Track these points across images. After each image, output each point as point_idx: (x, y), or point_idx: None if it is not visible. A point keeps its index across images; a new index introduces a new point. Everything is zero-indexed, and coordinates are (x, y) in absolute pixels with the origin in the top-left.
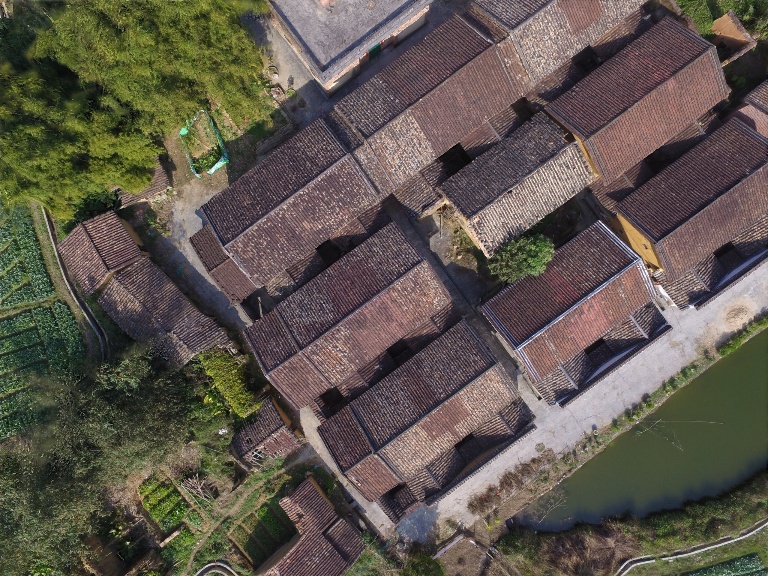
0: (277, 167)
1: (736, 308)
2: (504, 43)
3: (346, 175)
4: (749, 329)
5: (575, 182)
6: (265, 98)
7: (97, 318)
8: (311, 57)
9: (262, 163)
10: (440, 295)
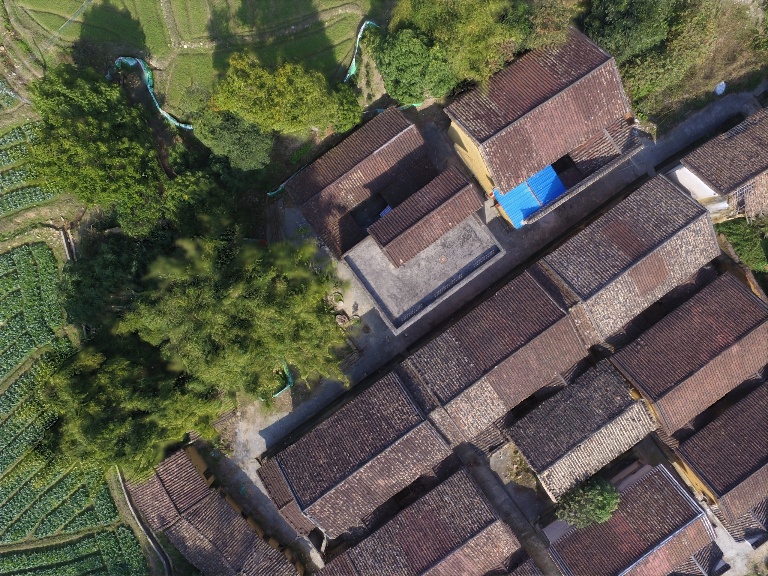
0: (352, 423)
1: None
2: (575, 307)
3: (422, 437)
4: None
5: (640, 431)
6: None
7: (162, 544)
8: (384, 310)
9: (336, 416)
10: (510, 545)
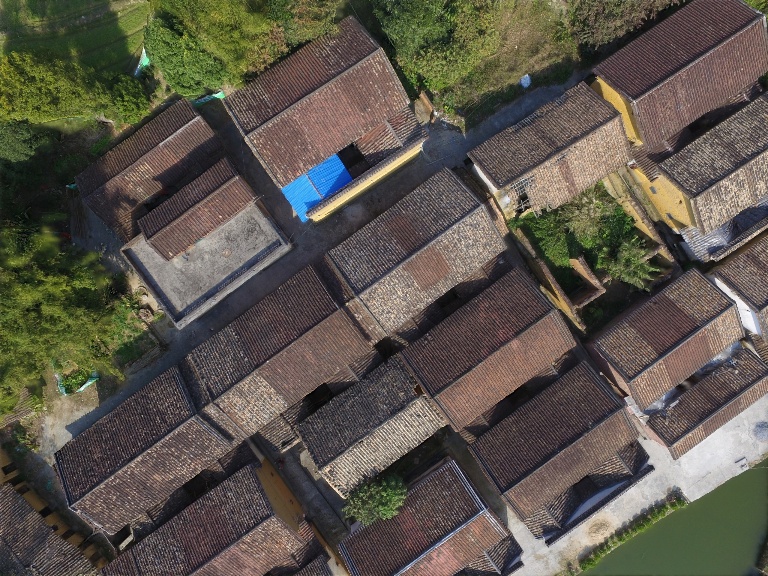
0: (129, 418)
1: (598, 523)
2: (353, 301)
3: (195, 432)
4: (610, 543)
5: (428, 427)
6: (134, 320)
7: None
8: (167, 303)
9: (116, 410)
10: (293, 541)
